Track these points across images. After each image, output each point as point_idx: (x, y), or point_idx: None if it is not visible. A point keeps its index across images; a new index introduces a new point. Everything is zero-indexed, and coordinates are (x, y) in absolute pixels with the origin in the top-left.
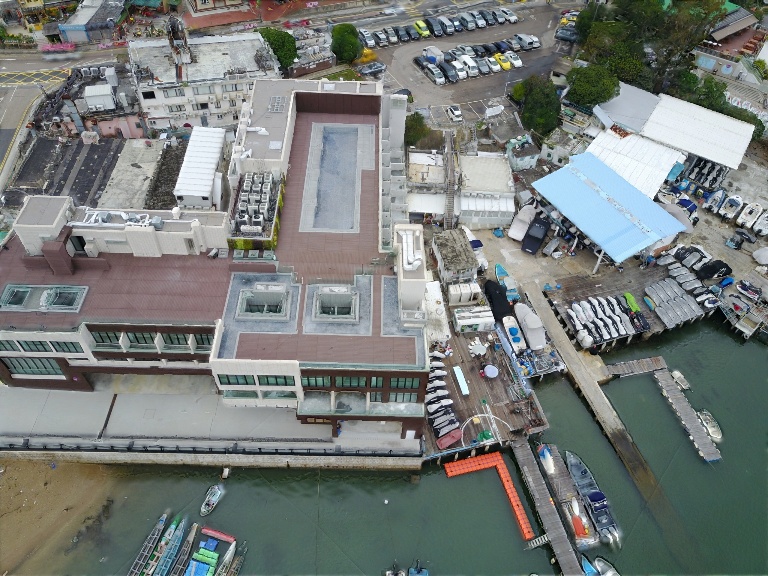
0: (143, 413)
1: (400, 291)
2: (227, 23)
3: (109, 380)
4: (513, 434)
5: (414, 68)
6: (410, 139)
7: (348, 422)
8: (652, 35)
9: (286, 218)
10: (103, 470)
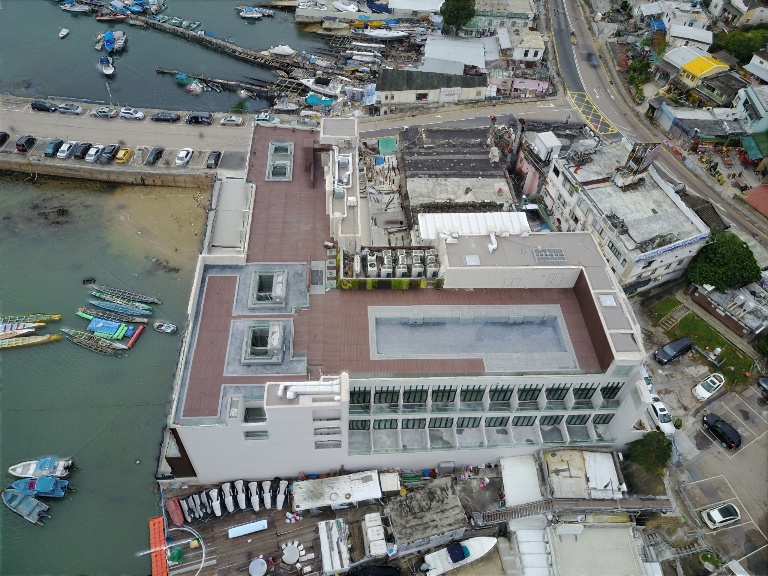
0: None
1: None
2: None
3: None
4: None
5: None
6: (634, 450)
7: None
8: None
9: (387, 294)
10: None
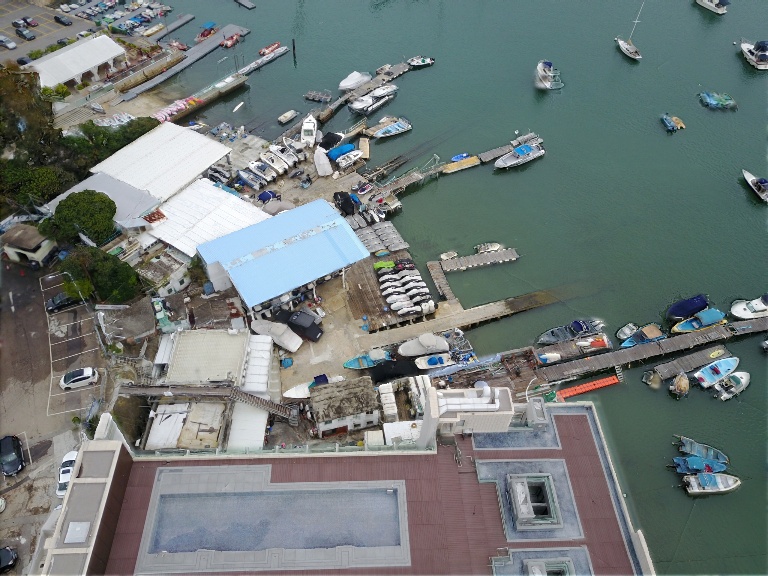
0: None
1: None
2: None
3: None
4: None
5: None
6: None
7: None
8: (3, 142)
9: None
10: None
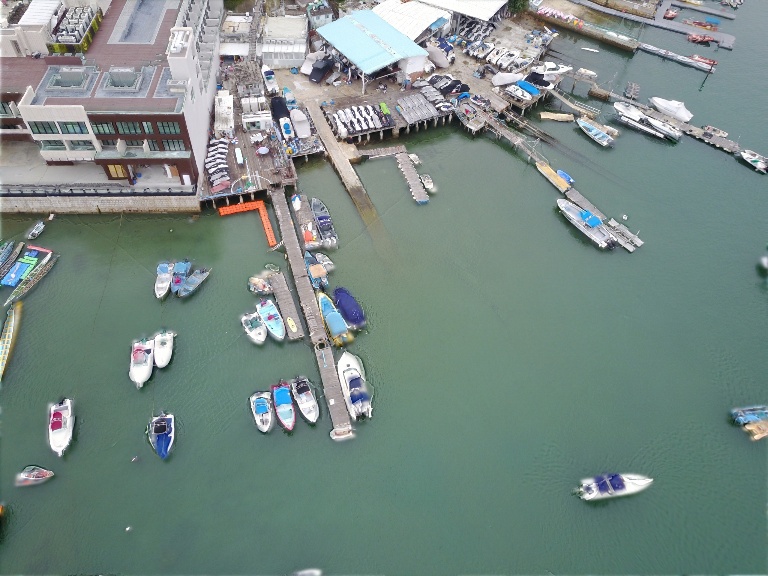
0: None
1: (170, 70)
2: None
3: None
4: (273, 187)
5: None
6: (229, 5)
7: (144, 177)
8: None
9: (99, 37)
10: None
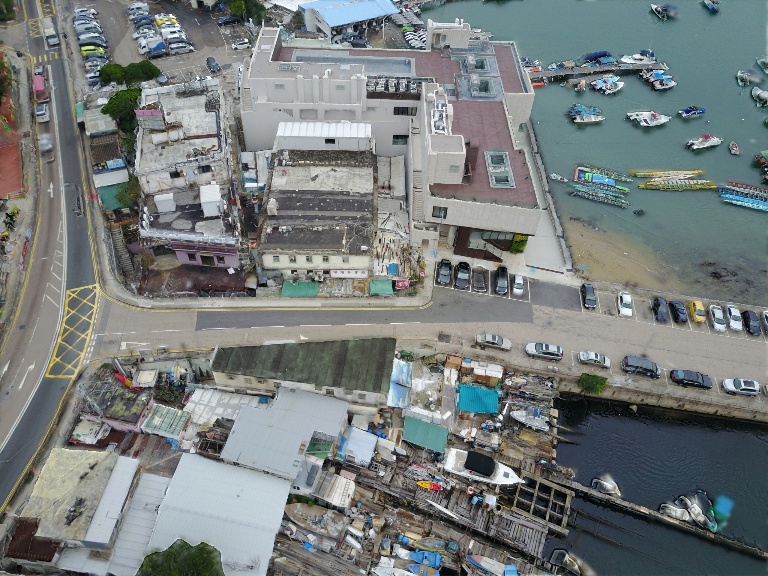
0: None
1: None
2: (21, 162)
3: None
4: None
5: (162, 60)
6: None
7: None
8: None
9: None
10: None
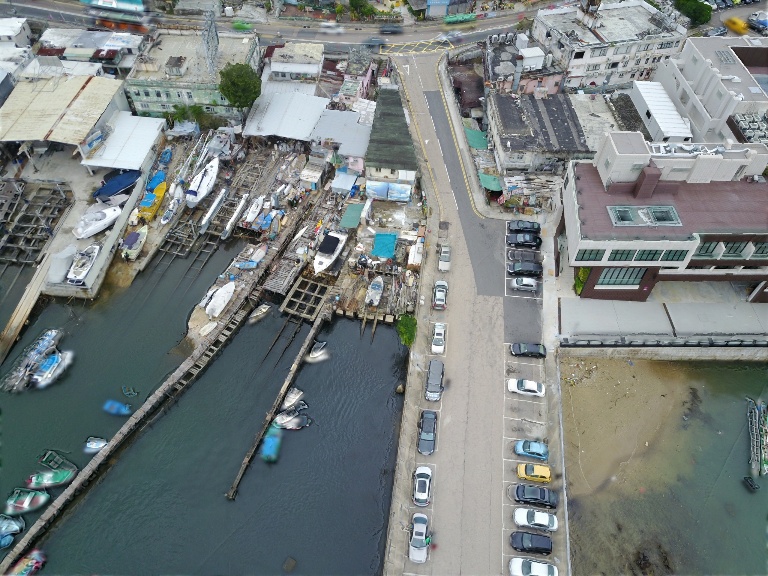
0: (698, 317)
1: None
2: None
3: (650, 293)
4: None
5: (749, 31)
6: None
7: None
8: None
9: None
10: (671, 366)
